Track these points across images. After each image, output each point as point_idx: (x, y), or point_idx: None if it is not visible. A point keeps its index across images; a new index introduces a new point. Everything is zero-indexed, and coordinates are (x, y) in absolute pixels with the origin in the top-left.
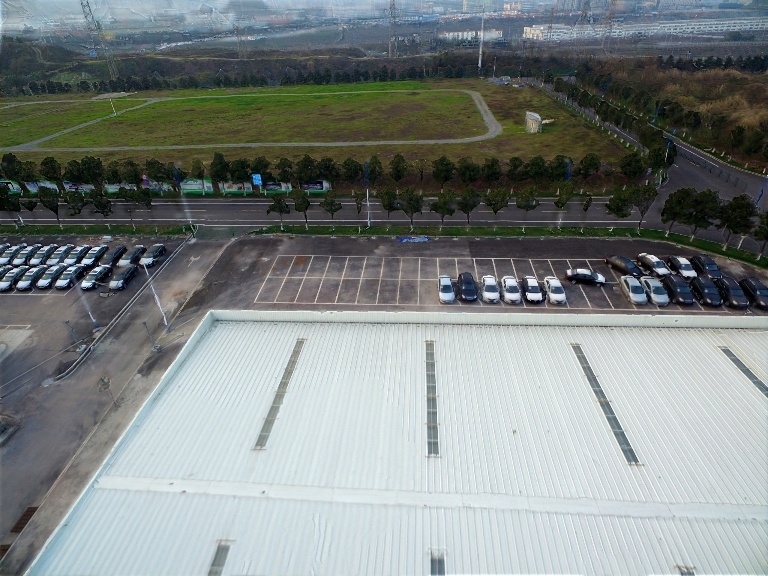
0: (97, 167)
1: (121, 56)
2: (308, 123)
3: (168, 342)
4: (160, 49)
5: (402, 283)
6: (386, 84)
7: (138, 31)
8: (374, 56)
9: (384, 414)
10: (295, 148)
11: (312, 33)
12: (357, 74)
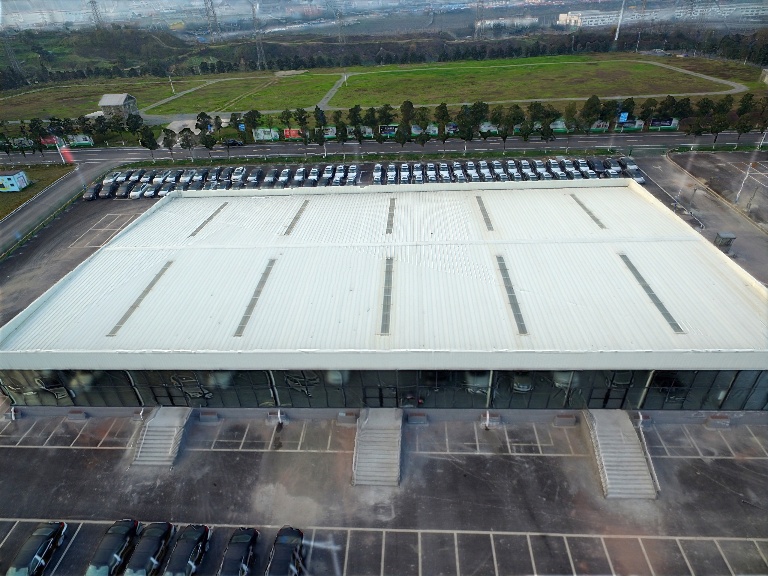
0: (486, 110)
1: (231, 42)
2: (549, 85)
3: (747, 207)
4: (254, 36)
5: None
6: (547, 58)
7: (246, 18)
8: (463, 39)
9: None
10: (584, 101)
11: (403, 18)
12: (511, 50)
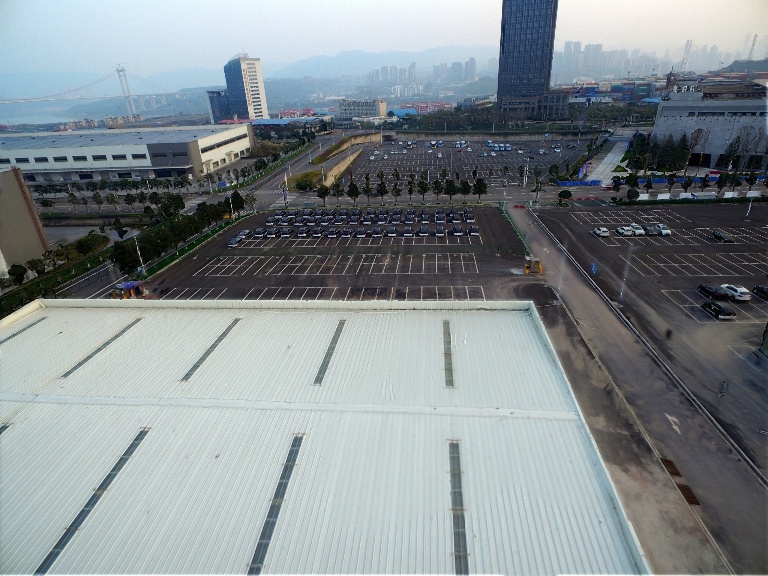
0: None
1: None
2: None
3: None
4: None
5: None
6: None
7: None
8: None
9: (335, 475)
10: None
11: None
12: None
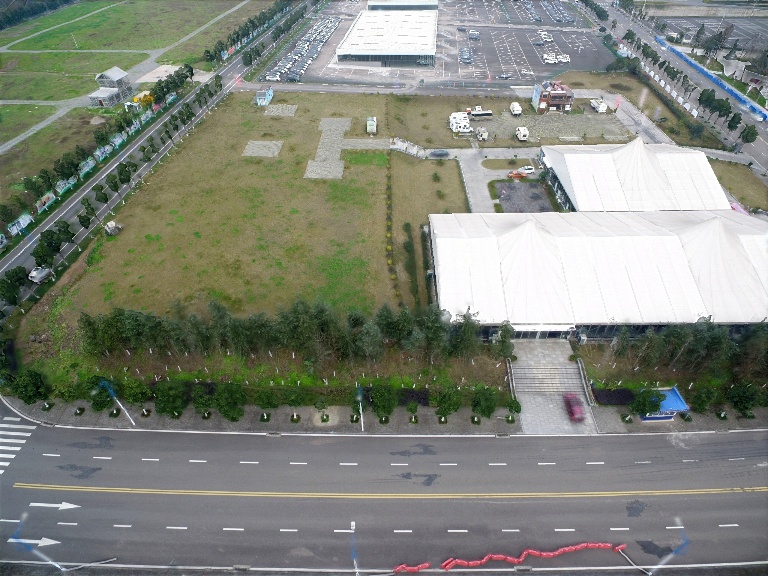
0: None
1: None
2: None
3: None
4: None
5: (349, 5)
6: (80, 7)
7: None
8: None
9: None
10: None
11: None
12: (39, 7)
